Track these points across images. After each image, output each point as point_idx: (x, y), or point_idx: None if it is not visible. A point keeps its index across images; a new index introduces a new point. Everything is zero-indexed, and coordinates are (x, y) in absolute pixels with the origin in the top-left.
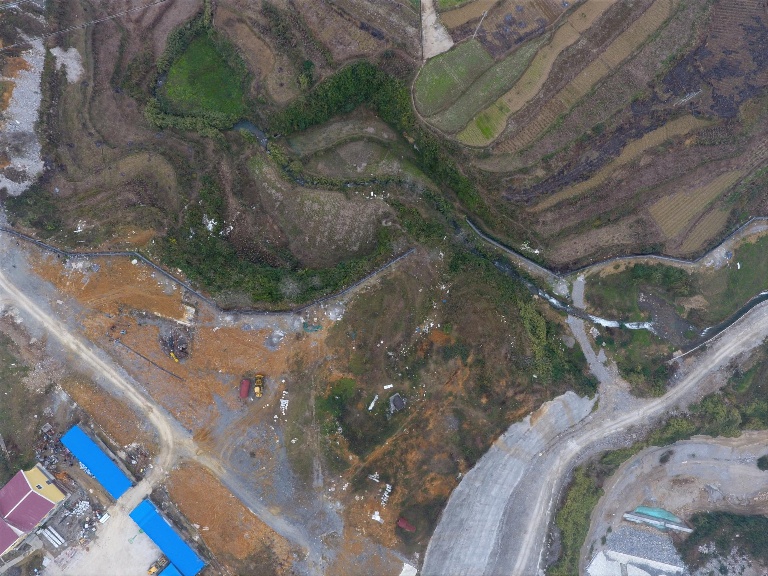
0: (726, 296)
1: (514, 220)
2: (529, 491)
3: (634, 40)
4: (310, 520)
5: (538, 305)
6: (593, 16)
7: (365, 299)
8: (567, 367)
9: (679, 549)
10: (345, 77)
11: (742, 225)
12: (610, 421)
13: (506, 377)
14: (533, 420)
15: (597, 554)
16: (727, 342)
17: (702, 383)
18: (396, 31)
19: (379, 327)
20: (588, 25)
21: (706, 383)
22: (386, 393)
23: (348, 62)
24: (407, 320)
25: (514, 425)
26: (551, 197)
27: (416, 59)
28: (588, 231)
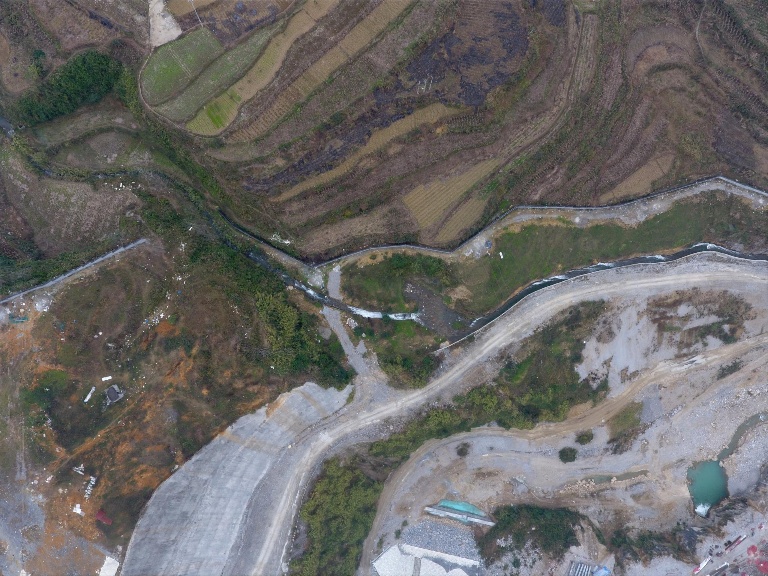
0: (489, 286)
1: (260, 210)
2: (275, 484)
3: (374, 27)
4: (11, 513)
5: (292, 296)
6: (329, 3)
7: (77, 290)
8: (315, 358)
9: (478, 543)
10: (75, 66)
11: (502, 214)
12: (366, 413)
13: (232, 368)
14: (269, 412)
15: (389, 548)
16: (496, 333)
17: (468, 374)
18: (124, 19)
19: (95, 318)
20: (324, 12)
21: (474, 374)
22: (104, 385)
23: (78, 51)
24: (130, 311)
25: (245, 417)
26: (295, 187)
27: (144, 48)
28: (341, 221)
